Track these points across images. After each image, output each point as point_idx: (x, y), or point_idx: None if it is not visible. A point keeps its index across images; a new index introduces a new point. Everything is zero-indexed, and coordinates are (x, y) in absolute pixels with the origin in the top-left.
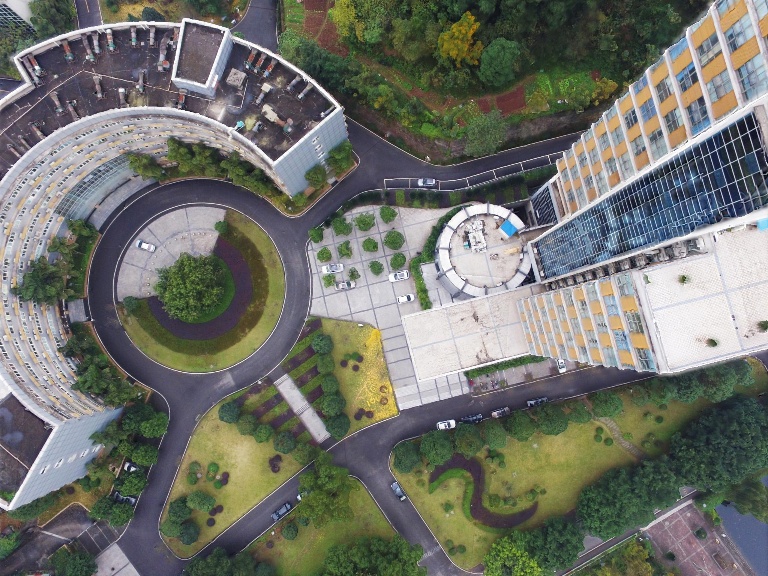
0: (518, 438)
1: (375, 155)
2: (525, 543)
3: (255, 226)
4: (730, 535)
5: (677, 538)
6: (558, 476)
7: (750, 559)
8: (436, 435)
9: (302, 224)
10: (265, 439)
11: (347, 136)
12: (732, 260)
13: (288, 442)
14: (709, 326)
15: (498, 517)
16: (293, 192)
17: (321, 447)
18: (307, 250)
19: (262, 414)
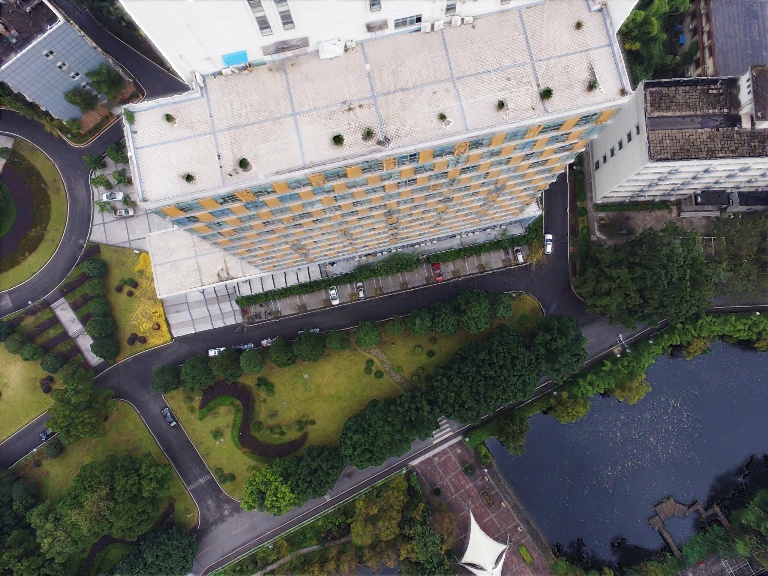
0: (277, 364)
1: (160, 88)
2: (283, 470)
3: (41, 154)
4: (502, 474)
5: (446, 474)
6: (328, 407)
7: (522, 499)
8: (193, 357)
9: (88, 153)
10: (30, 357)
11: (107, 60)
12: (223, 102)
13: (52, 361)
14: (194, 164)
15: (267, 446)
16: (61, 116)
17: (94, 370)
18: (90, 178)
19: (36, 335)
